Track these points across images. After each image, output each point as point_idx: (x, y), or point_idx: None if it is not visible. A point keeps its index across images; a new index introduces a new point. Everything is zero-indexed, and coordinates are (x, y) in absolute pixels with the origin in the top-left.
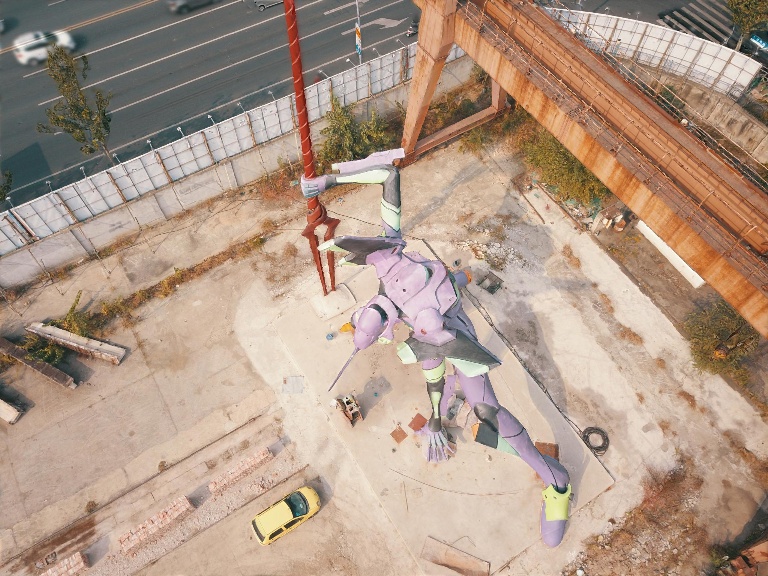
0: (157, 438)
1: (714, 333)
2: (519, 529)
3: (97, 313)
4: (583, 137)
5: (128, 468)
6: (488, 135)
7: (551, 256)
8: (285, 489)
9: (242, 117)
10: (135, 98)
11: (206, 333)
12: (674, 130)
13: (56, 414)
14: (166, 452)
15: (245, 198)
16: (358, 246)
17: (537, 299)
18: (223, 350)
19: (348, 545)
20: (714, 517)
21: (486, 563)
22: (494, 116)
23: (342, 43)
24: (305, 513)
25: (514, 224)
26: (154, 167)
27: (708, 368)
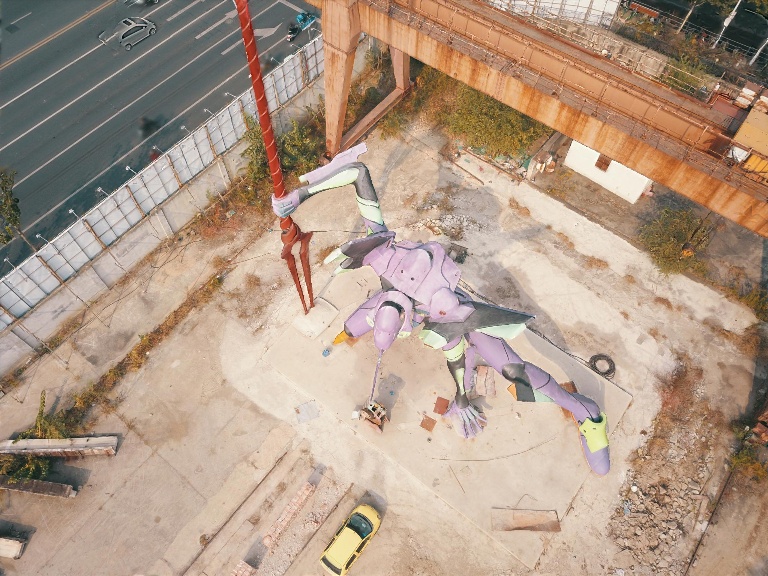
0: (187, 514)
1: (671, 237)
2: (569, 470)
3: (69, 409)
4: (521, 89)
5: (168, 556)
6: (402, 116)
7: (501, 212)
8: (339, 516)
9: (163, 160)
10: (24, 173)
11: (197, 391)
12: (597, 62)
13: (65, 530)
14: (202, 525)
15: (185, 243)
16: (359, 249)
17: (504, 255)
18: (222, 402)
19: (420, 546)
20: (722, 398)
21: (552, 512)
22: (402, 97)
23: (226, 63)
24: (370, 531)
25: (457, 193)
26: (84, 237)
27: (671, 270)
